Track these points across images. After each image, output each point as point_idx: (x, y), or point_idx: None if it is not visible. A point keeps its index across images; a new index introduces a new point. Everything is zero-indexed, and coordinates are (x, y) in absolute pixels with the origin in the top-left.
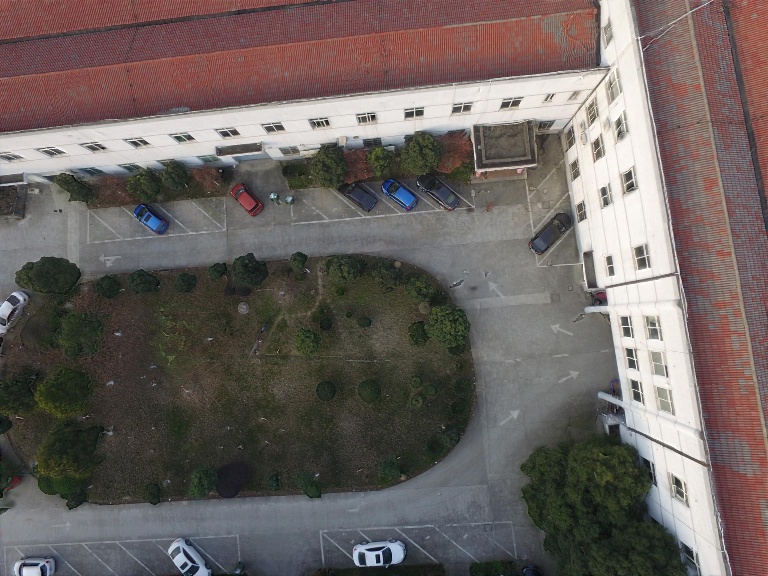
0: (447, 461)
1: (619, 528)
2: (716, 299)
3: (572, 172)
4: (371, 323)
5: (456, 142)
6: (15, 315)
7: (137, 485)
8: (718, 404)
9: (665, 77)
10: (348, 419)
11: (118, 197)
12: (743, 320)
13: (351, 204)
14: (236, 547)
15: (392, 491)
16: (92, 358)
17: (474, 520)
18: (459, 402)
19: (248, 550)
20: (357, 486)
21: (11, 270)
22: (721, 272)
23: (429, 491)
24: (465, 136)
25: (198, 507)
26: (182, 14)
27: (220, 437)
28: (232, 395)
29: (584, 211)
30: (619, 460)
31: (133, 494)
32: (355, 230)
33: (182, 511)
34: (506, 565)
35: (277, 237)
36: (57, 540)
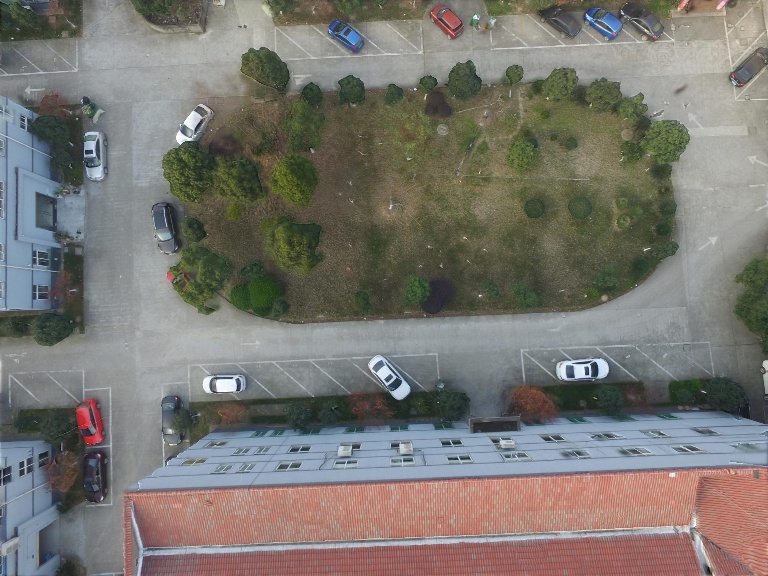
0: (647, 284)
1: None
2: None
3: None
4: None
5: None
6: (201, 128)
7: (332, 303)
8: None
9: None
10: (551, 240)
11: (307, 15)
12: None
13: (552, 32)
14: (435, 365)
15: (593, 312)
16: None
17: (673, 340)
18: (665, 223)
19: (448, 368)
20: (558, 306)
21: (191, 85)
22: None
23: (629, 312)
24: None
25: (395, 326)
26: None
27: (419, 256)
28: (432, 215)
29: None
30: None
31: (327, 312)
32: (556, 58)
33: (379, 330)
34: (705, 382)
35: (476, 62)
36: (246, 358)
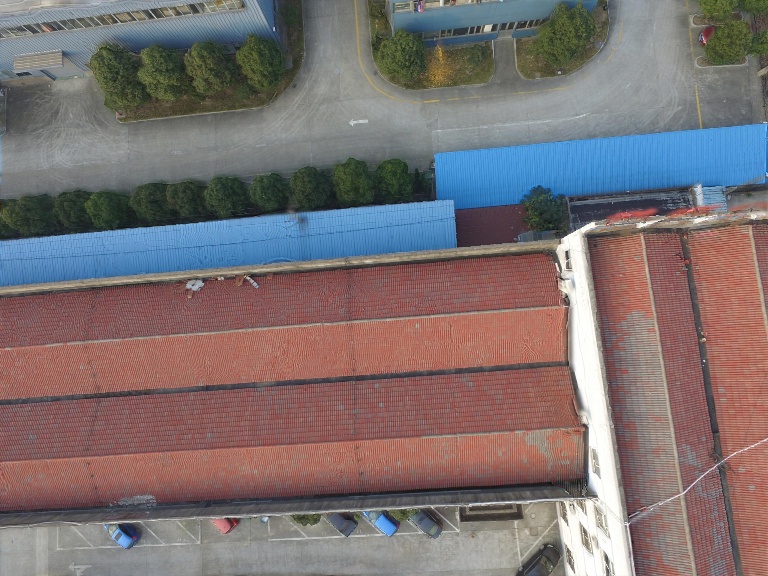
0: None
1: None
2: None
3: (561, 506)
4: None
5: None
6: None
7: None
8: None
9: (656, 553)
10: None
11: None
12: None
13: None
14: None
15: None
16: None
17: None
18: None
19: None
20: None
21: None
22: None
23: None
24: None
25: None
26: (147, 387)
27: None
28: None
29: (573, 564)
30: None
31: None
32: (334, 550)
33: None
34: None
35: (253, 553)
36: None
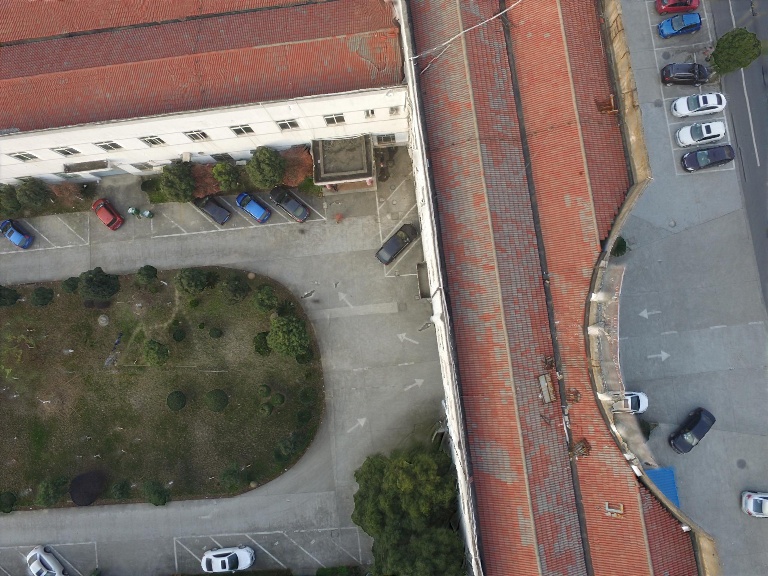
0: (296, 468)
1: (417, 534)
2: (482, 312)
3: None
4: (224, 334)
5: (298, 156)
6: None
7: None
8: (484, 414)
9: (443, 95)
10: (201, 428)
11: None
12: (504, 332)
13: (208, 217)
14: (94, 554)
15: (243, 498)
16: None
17: (321, 526)
18: (304, 410)
19: (105, 557)
20: (210, 493)
21: None
22: (486, 285)
23: (278, 498)
24: (305, 150)
25: (58, 515)
26: (16, 37)
27: (79, 446)
28: (91, 405)
29: (421, 222)
30: (422, 468)
31: None
32: (212, 243)
33: (43, 519)
34: (351, 570)
35: (137, 250)
36: None
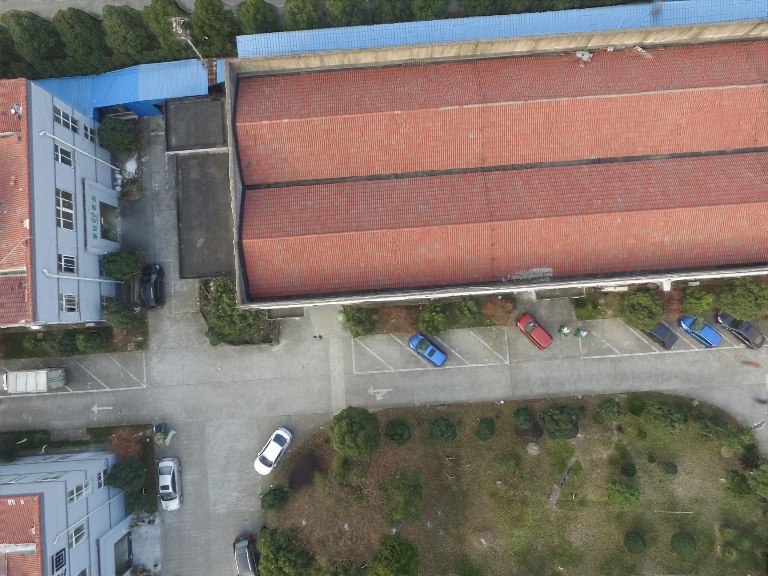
0: None
1: None
2: None
3: None
4: None
5: None
6: (280, 455)
7: None
8: None
9: None
10: (651, 568)
11: (386, 323)
12: None
13: (644, 338)
14: None
15: None
16: (368, 502)
17: None
18: None
19: None
20: None
21: (267, 402)
22: None
23: None
24: None
25: None
26: (535, 160)
27: None
28: (526, 543)
29: None
30: None
31: None
32: (649, 366)
33: None
34: None
35: (565, 372)
36: None
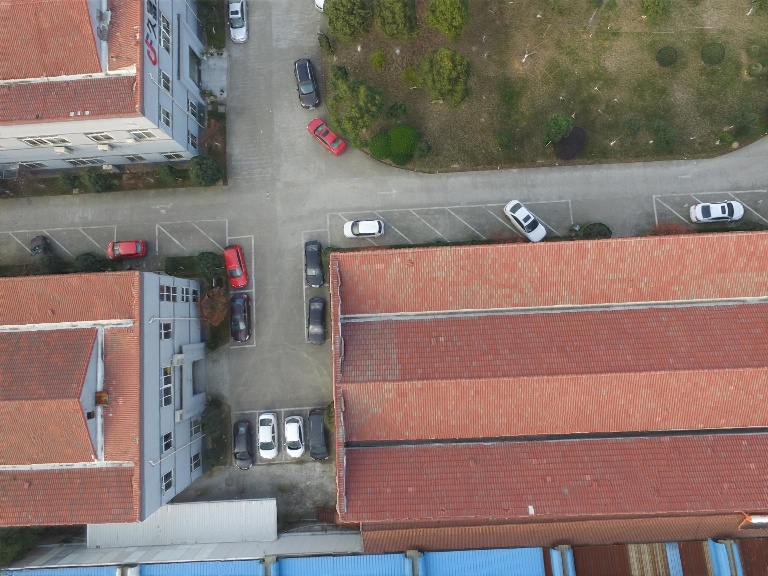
0: None
1: None
2: None
3: None
4: (701, 3)
5: None
6: None
7: (467, 153)
8: None
9: None
10: (681, 90)
11: None
12: None
13: None
14: (568, 211)
15: (724, 159)
16: (418, 33)
17: None
18: None
19: (581, 214)
20: (689, 154)
21: None
22: None
23: (761, 159)
24: None
25: (528, 174)
26: None
27: (551, 107)
28: (563, 68)
29: None
30: None
31: (462, 162)
32: None
33: (512, 178)
34: None
35: None
36: (383, 206)
